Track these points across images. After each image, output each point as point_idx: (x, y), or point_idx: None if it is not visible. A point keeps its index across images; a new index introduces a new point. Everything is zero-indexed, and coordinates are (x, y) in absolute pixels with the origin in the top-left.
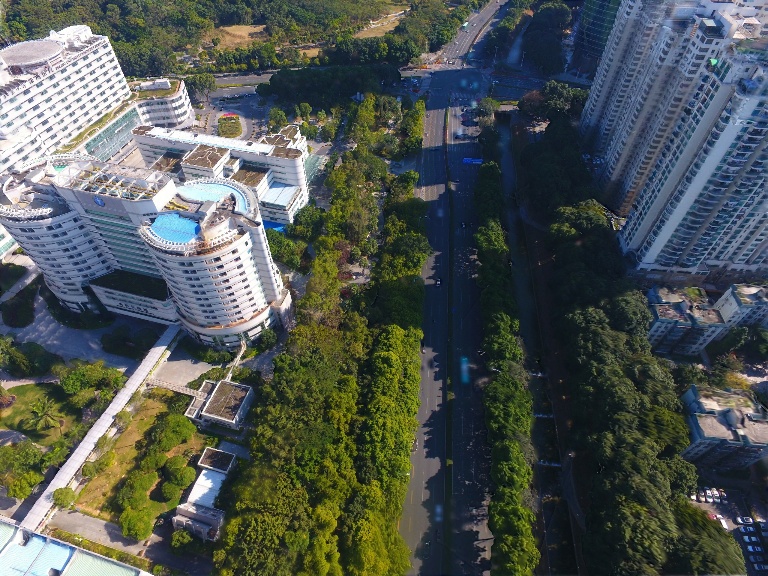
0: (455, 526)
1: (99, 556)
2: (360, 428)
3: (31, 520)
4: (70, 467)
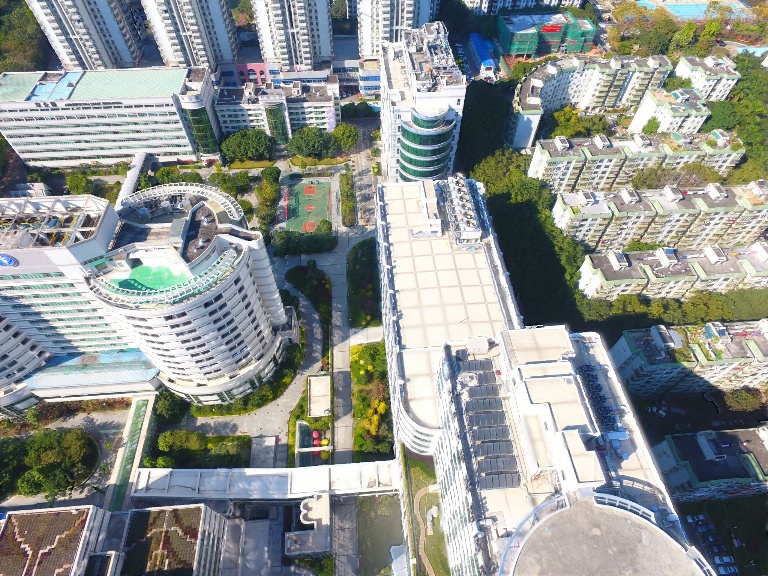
0: None
1: (8, 101)
2: None
3: (138, 156)
4: (129, 180)
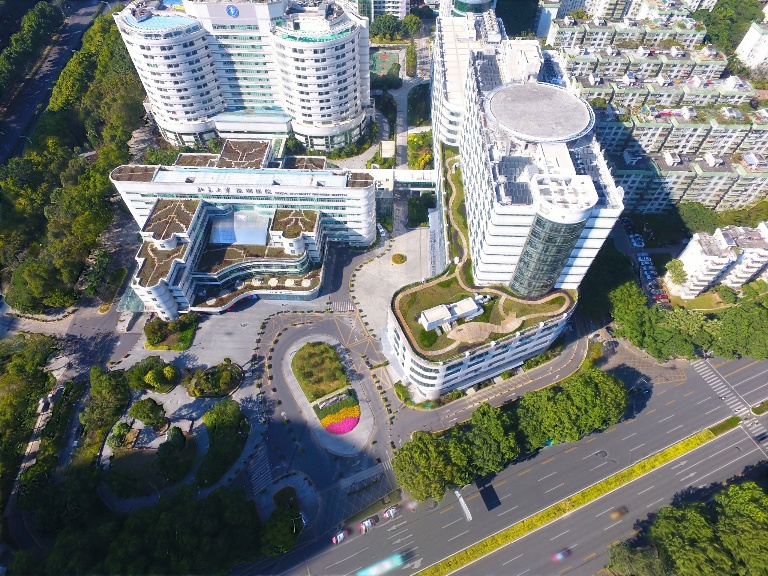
0: (62, 67)
1: None
2: (95, 56)
3: None
4: None
